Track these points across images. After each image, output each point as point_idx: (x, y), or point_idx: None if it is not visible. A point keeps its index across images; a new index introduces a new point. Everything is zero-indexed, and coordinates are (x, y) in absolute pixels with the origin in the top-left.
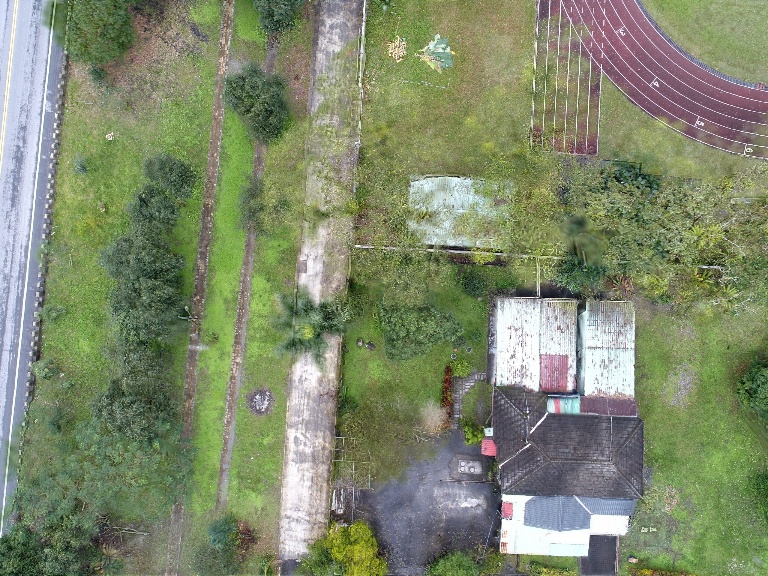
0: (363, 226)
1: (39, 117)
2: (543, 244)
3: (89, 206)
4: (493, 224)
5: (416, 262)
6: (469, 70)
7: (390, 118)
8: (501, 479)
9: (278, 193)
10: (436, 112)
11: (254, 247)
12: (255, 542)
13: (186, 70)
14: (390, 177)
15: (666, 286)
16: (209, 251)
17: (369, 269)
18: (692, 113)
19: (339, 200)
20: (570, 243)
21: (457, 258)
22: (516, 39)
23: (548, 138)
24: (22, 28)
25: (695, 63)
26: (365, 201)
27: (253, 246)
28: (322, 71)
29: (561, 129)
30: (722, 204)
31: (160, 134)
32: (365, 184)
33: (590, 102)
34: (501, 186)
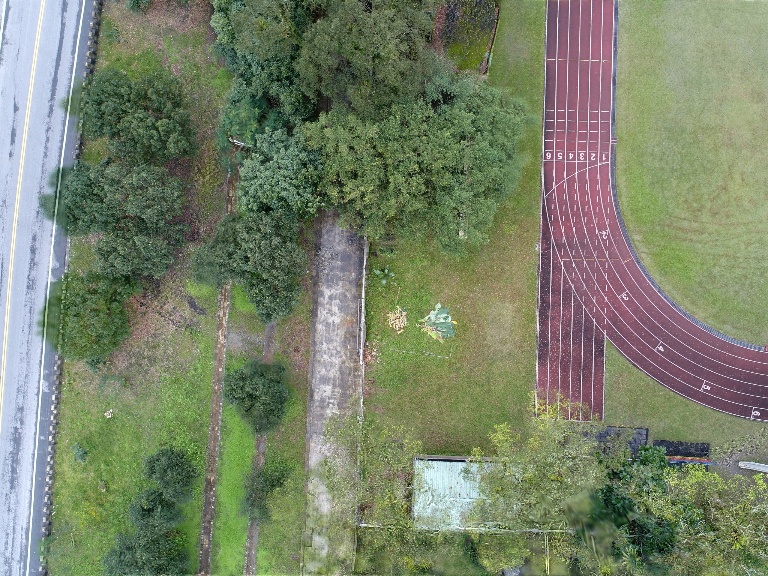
0: (368, 499)
1: (36, 397)
2: (551, 520)
3: (89, 484)
4: (500, 511)
5: (423, 542)
6: (471, 339)
7: (392, 389)
8: None
9: (281, 467)
10: (439, 382)
11: (258, 520)
12: None
13: (184, 344)
14: (394, 449)
15: (676, 553)
16: (213, 526)
17: (375, 544)
18: (698, 377)
19: (343, 473)
20: (579, 526)
21: (464, 530)
22: (518, 307)
23: (553, 406)
24: (16, 308)
25: (700, 326)
26: (369, 473)
27: (257, 519)
28: (322, 342)
29: (566, 396)
30: (730, 467)
31: (160, 409)
32: (369, 456)
33: (594, 368)
34: (507, 464)
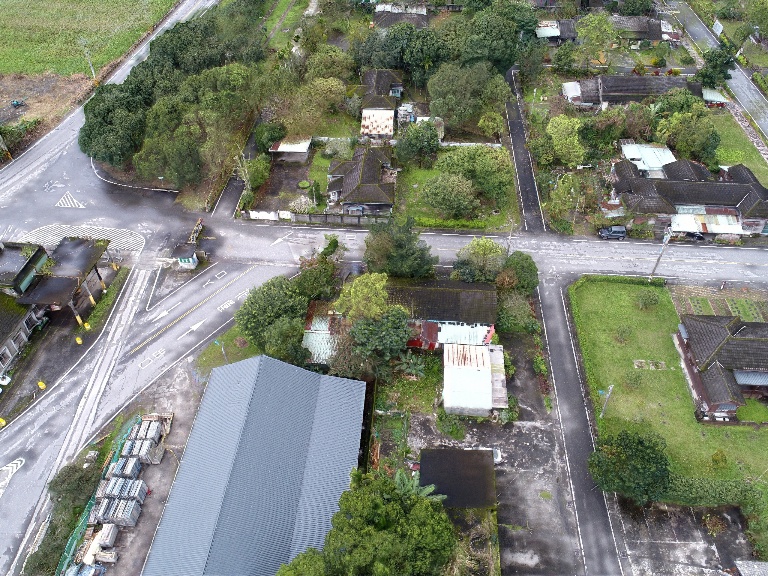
0: None
1: None
2: (393, 1)
3: None
4: None
5: None
6: None
7: None
8: (375, 25)
9: None
10: None
11: None
12: (275, 52)
13: None
14: None
15: None
16: None
17: (331, 8)
18: None
19: (323, 1)
20: None
21: (363, 7)
22: None
23: None
24: None
25: None
26: None
27: (290, 8)
28: None
29: None
30: None
31: None
32: None
33: None
34: None
